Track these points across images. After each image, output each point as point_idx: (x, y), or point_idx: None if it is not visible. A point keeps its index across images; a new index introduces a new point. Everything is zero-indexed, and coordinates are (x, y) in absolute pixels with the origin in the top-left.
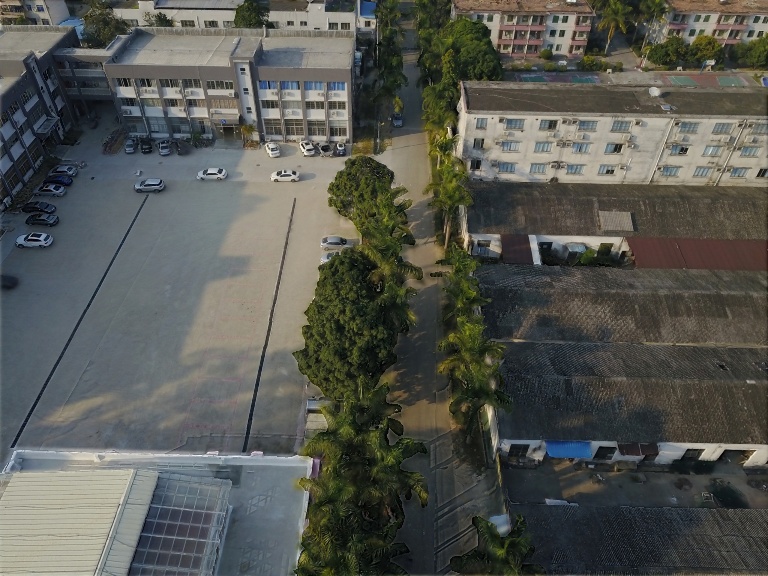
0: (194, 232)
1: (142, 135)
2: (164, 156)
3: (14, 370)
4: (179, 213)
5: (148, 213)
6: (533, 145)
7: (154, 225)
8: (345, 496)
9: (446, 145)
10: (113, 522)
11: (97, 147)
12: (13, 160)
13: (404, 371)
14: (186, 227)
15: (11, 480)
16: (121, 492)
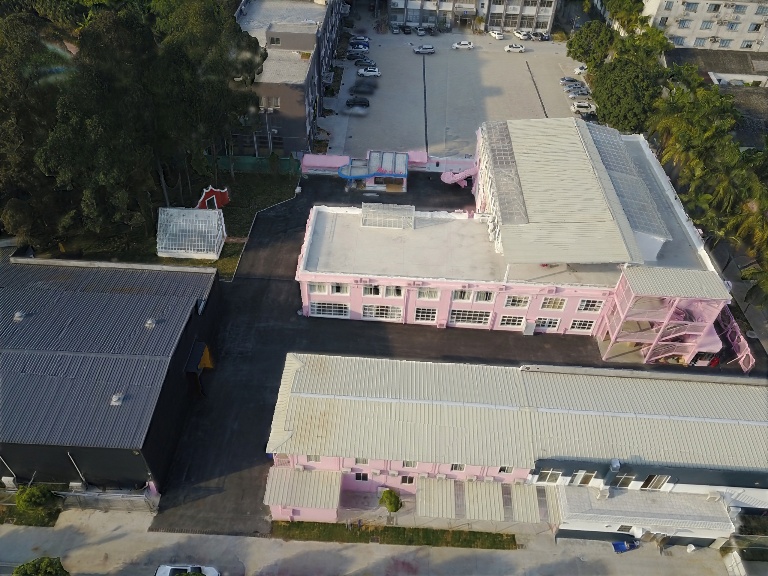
0: (469, 74)
1: (400, 23)
2: (421, 36)
3: (403, 129)
4: (452, 65)
5: (431, 64)
6: (700, 23)
7: (440, 70)
8: (699, 115)
9: (645, 19)
10: (577, 131)
11: (370, 30)
12: (336, 26)
13: (646, 137)
14: (462, 72)
15: (507, 122)
16: (573, 123)
